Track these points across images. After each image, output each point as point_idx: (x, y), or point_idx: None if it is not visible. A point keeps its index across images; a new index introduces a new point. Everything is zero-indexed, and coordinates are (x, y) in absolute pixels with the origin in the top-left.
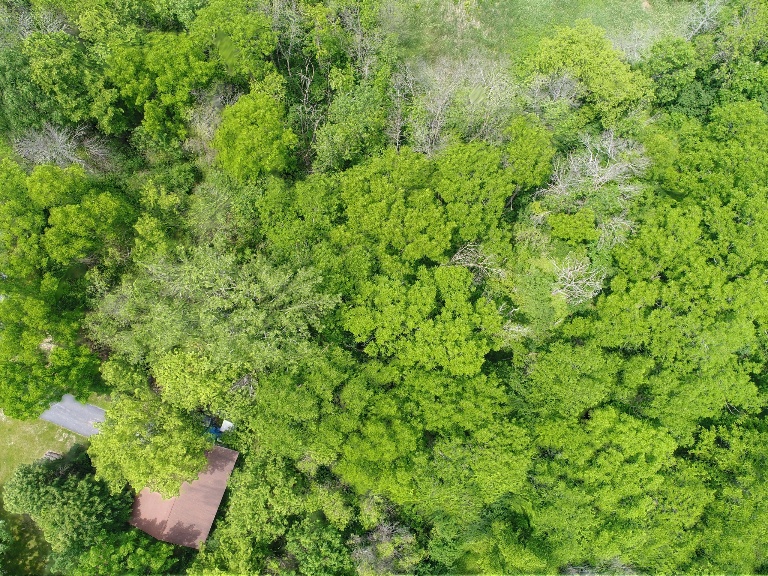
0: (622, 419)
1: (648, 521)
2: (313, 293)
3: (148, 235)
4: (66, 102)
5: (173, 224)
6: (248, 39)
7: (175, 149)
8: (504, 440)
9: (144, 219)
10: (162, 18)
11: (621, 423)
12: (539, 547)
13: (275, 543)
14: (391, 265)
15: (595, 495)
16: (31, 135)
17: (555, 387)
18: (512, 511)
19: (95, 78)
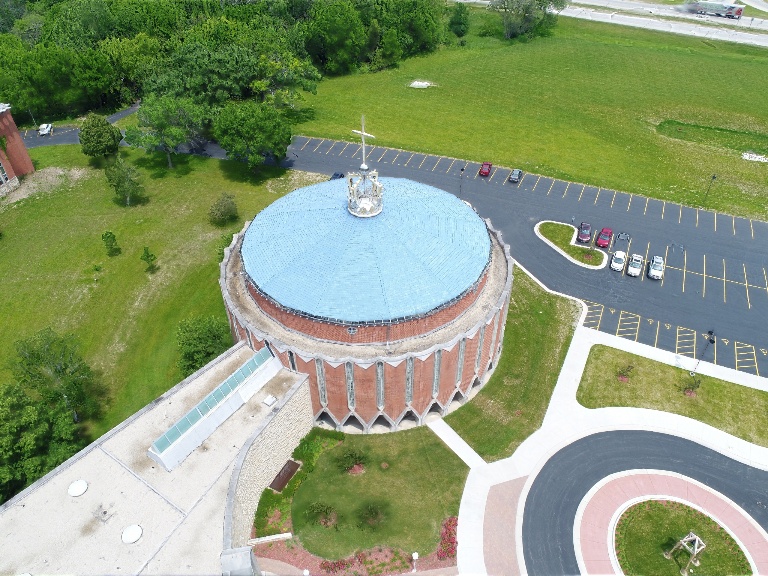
0: None
1: None
2: None
3: None
4: None
5: None
6: None
7: None
8: None
9: None
10: None
11: None
12: None
13: None
14: None
15: None
16: None
17: None
18: None
19: None
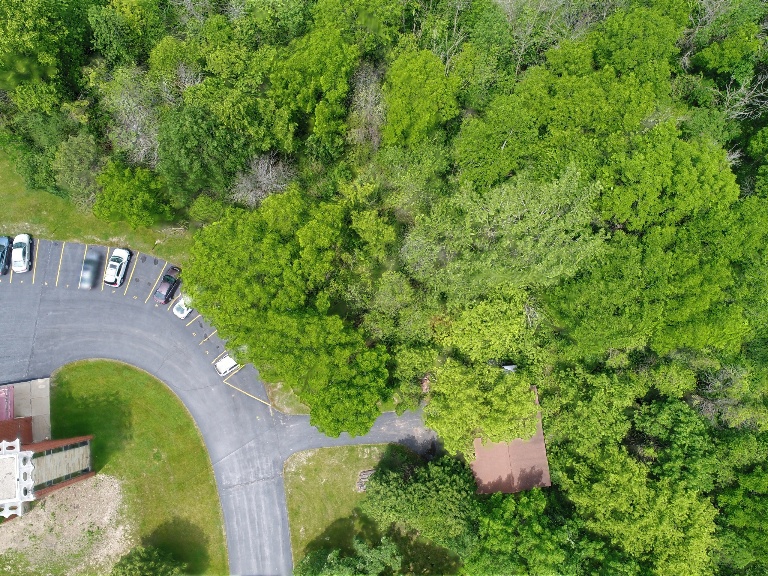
0: None
1: None
2: (582, 188)
3: (374, 225)
4: (257, 133)
5: (387, 207)
6: (384, 7)
7: (338, 148)
8: None
9: (356, 216)
10: (291, 26)
11: None
12: None
13: (624, 440)
14: (619, 141)
15: None
16: (238, 178)
17: None
18: None
19: (266, 103)
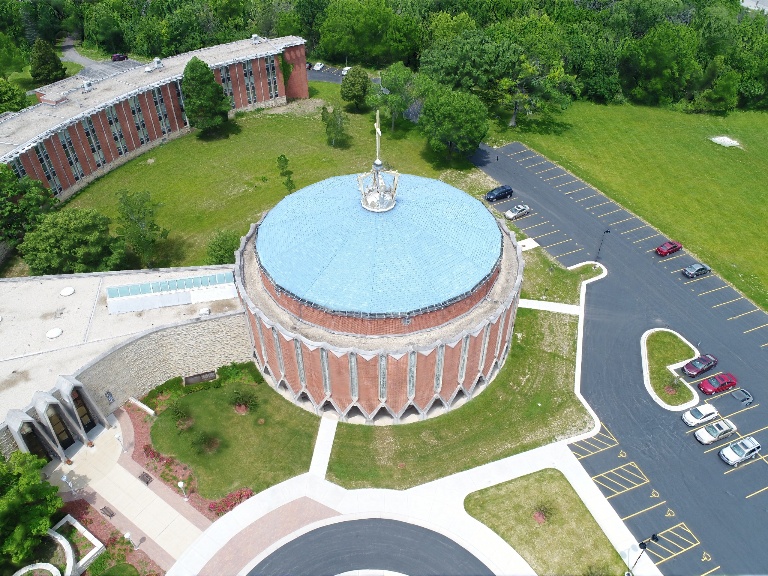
0: None
1: None
2: None
3: None
4: None
5: None
6: None
7: None
8: None
9: None
10: None
11: None
12: None
13: None
14: None
15: None
16: None
17: None
18: None
19: None
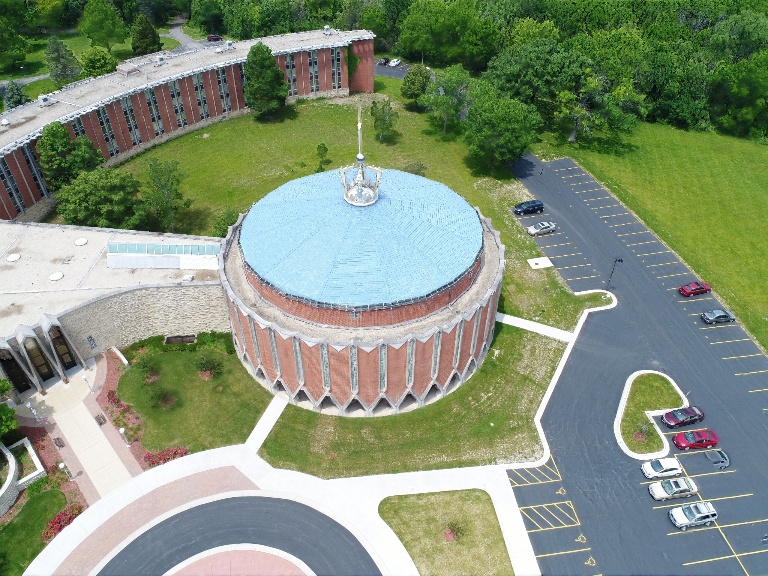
0: None
1: None
2: None
3: None
4: None
5: None
6: None
7: None
8: None
9: None
10: None
11: None
12: None
13: None
14: None
15: None
16: None
17: None
18: None
19: None
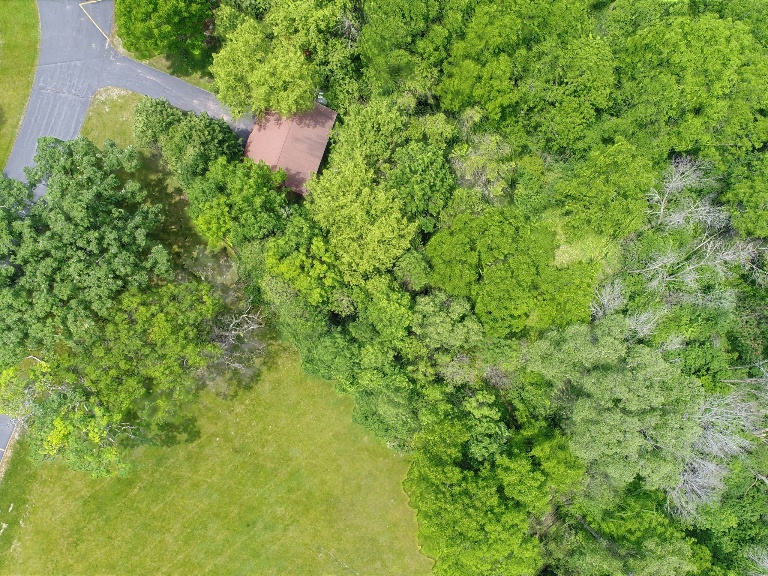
0: (701, 11)
1: (731, 88)
2: None
3: None
4: None
5: None
6: None
7: None
8: (591, 49)
9: None
10: None
11: (700, 13)
12: (628, 140)
13: None
14: None
15: (680, 75)
16: None
17: (634, 8)
18: (592, 155)
19: None
